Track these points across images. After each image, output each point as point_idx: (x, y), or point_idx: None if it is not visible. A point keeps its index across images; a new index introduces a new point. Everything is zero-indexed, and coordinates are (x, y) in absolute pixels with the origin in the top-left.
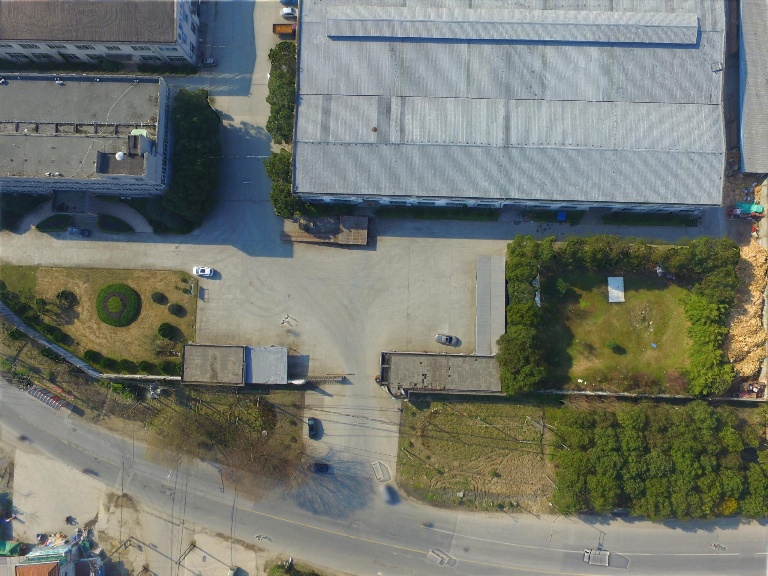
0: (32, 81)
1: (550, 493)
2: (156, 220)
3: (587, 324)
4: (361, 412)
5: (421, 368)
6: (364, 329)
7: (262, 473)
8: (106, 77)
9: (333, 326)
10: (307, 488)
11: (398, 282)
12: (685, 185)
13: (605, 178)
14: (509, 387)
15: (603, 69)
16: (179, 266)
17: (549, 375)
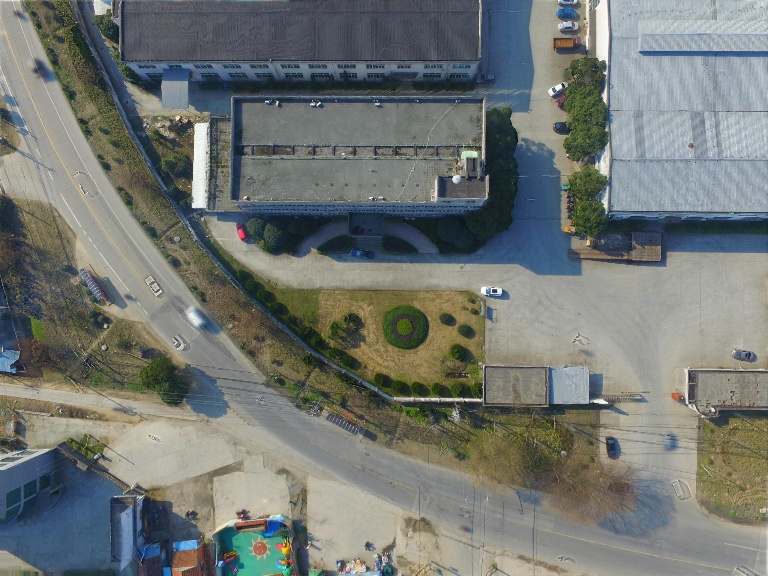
0: (348, 103)
1: None
2: (445, 240)
3: None
4: (658, 430)
5: (729, 385)
6: (657, 346)
7: (561, 494)
8: (426, 98)
9: (625, 344)
10: (607, 508)
11: (690, 298)
12: None
13: None
14: None
15: None
16: (465, 286)
17: None
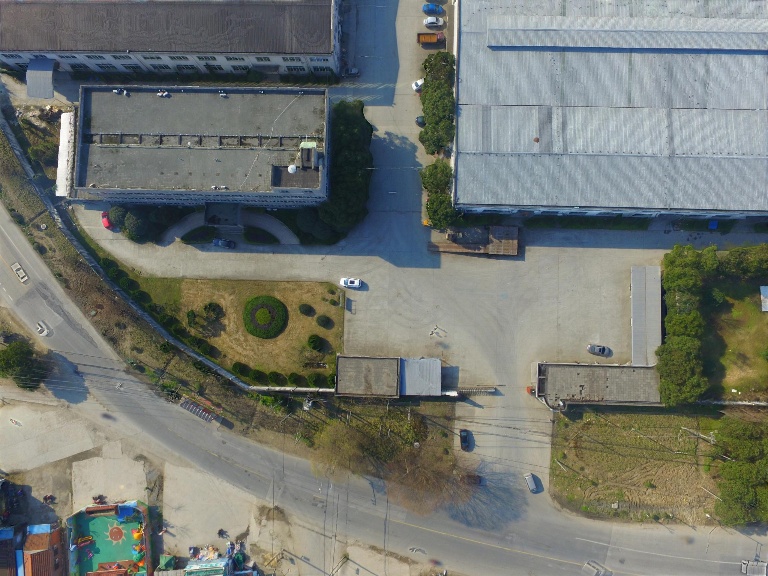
0: (195, 94)
1: (710, 504)
2: (304, 231)
3: (740, 334)
4: (512, 423)
5: (578, 379)
6: (514, 340)
7: (414, 485)
8: (271, 89)
9: (482, 337)
10: (460, 500)
11: (547, 292)
12: None
13: None
14: (670, 398)
15: (767, 77)
16: (325, 277)
17: None
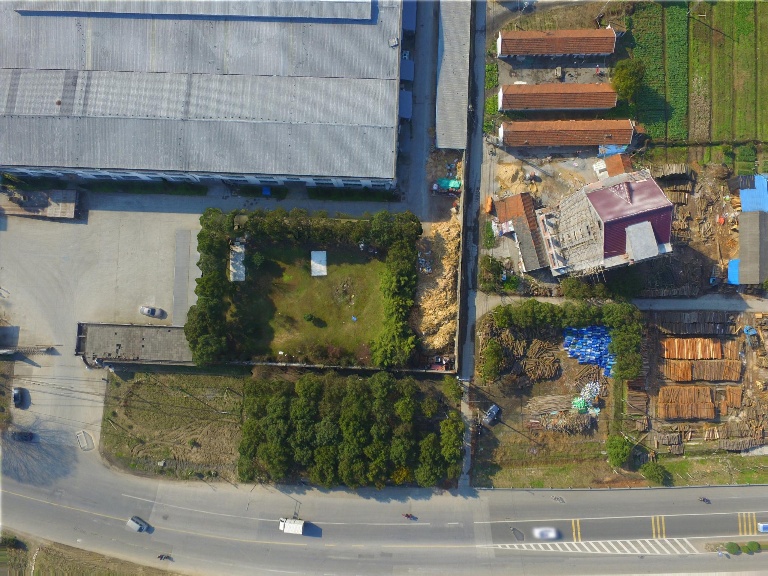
0: None
1: None
2: None
3: (289, 297)
4: (68, 382)
5: (115, 338)
6: (73, 301)
7: None
8: None
9: (43, 298)
10: (13, 456)
11: (108, 255)
12: (359, 158)
13: (281, 151)
14: None
15: (283, 44)
16: None
17: (251, 347)
